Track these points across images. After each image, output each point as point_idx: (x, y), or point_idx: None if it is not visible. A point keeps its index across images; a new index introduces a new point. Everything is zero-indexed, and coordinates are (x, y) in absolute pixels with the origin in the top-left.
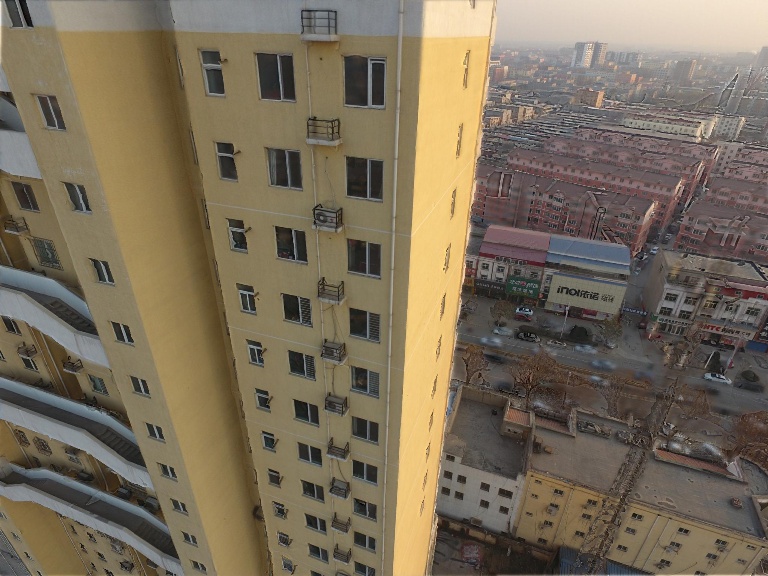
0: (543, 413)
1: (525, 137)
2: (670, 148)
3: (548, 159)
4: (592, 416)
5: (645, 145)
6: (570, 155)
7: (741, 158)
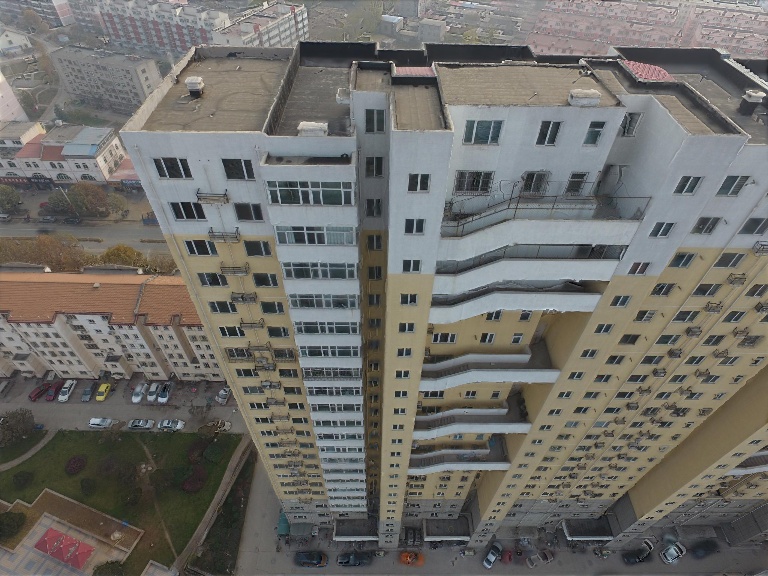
0: None
1: (475, 2)
2: (638, 13)
3: (566, 44)
4: None
5: (616, 11)
6: (562, 31)
7: (695, 18)
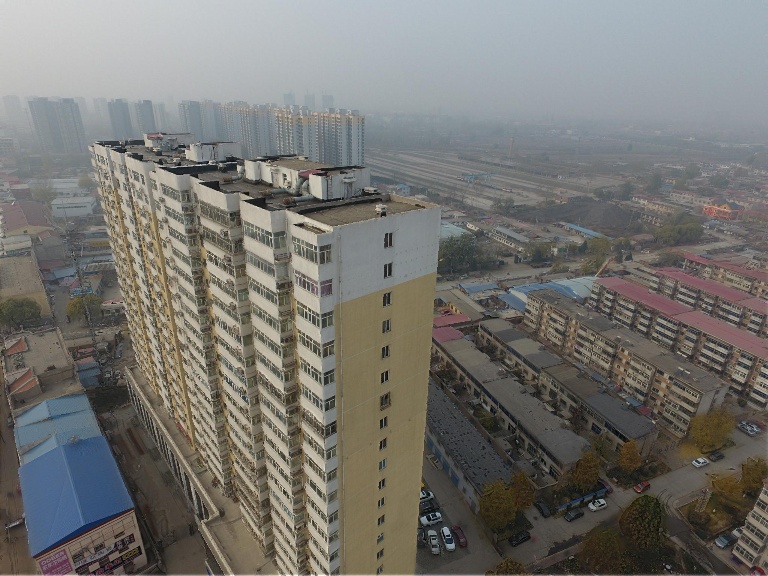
0: (7, 392)
1: None
2: None
3: None
4: (7, 369)
5: None
6: None
7: None
